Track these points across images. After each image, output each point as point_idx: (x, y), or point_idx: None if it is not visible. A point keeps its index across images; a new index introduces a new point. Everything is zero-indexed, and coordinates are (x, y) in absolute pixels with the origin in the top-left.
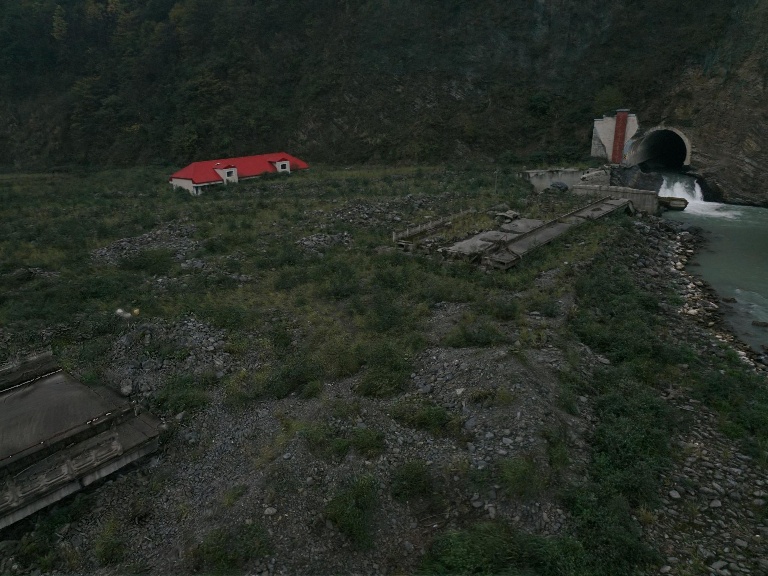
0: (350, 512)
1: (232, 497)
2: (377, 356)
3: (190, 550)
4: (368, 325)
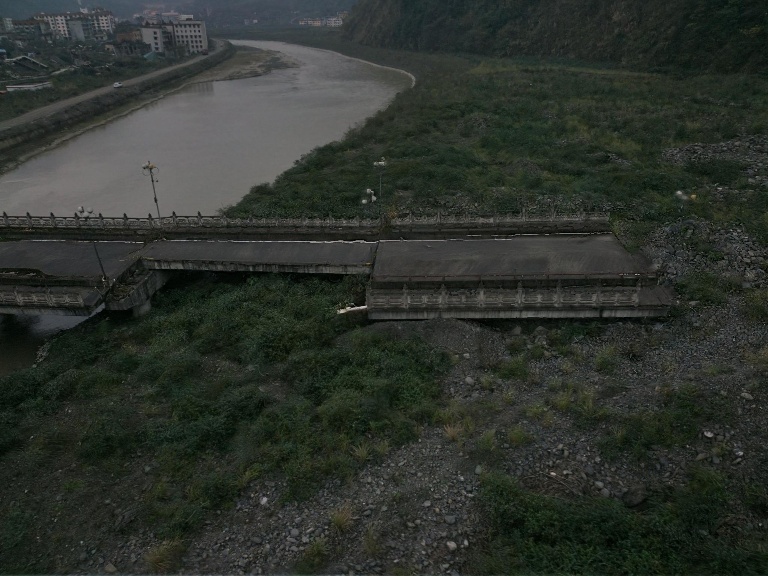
0: None
1: (716, 370)
2: None
3: (665, 389)
4: None
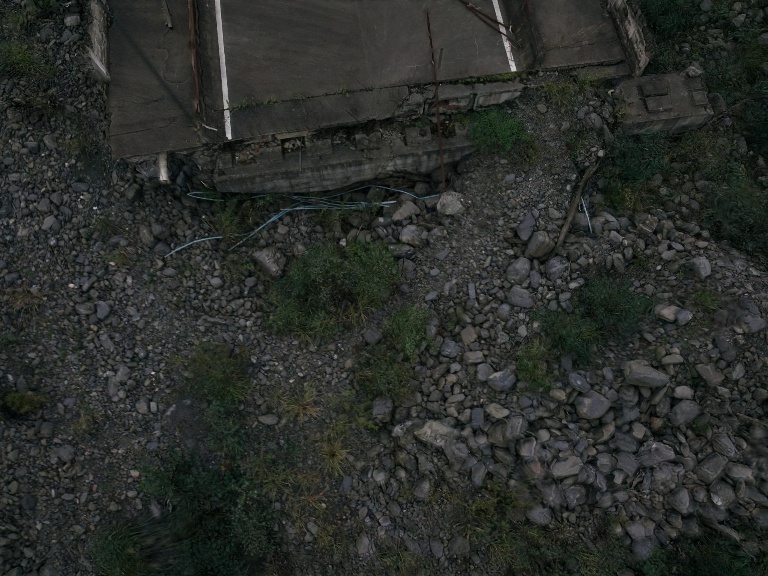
0: None
1: None
2: None
3: None
4: None
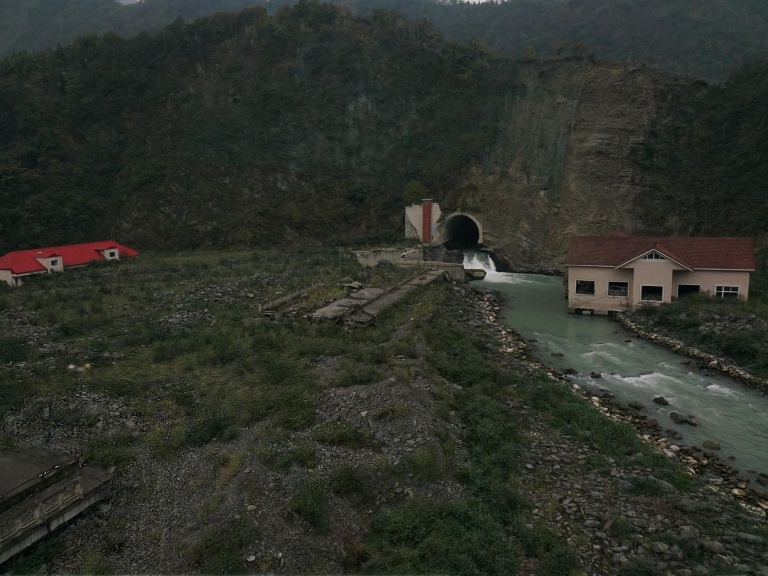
0: (310, 504)
1: (215, 503)
2: (283, 400)
3: (190, 549)
4: (261, 380)
